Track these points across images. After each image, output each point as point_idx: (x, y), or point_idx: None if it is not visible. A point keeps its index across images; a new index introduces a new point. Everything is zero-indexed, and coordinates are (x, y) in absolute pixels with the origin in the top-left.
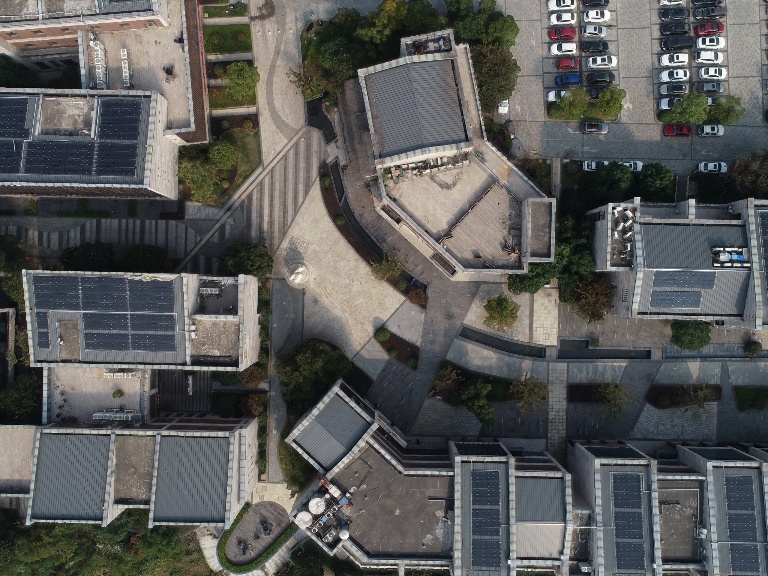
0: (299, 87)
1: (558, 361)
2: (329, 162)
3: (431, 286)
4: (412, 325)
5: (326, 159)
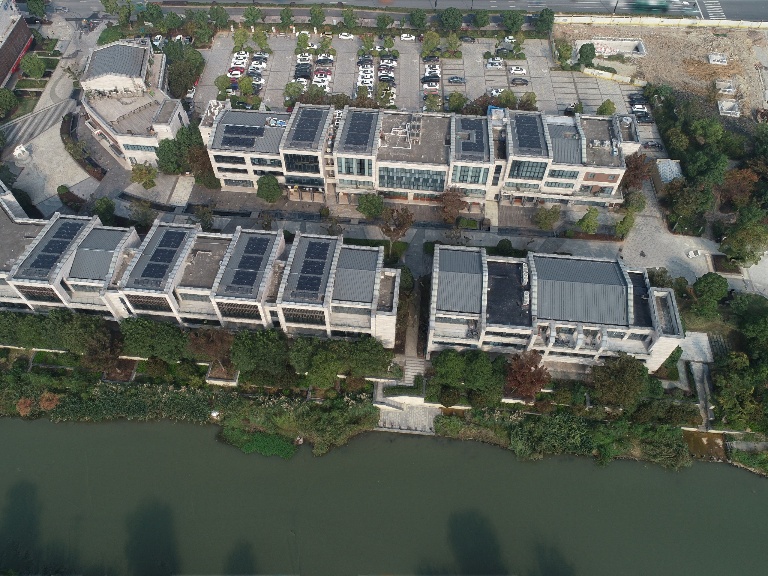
0: (66, 71)
1: (183, 214)
2: (74, 113)
3: (110, 171)
4: (88, 190)
5: (73, 112)
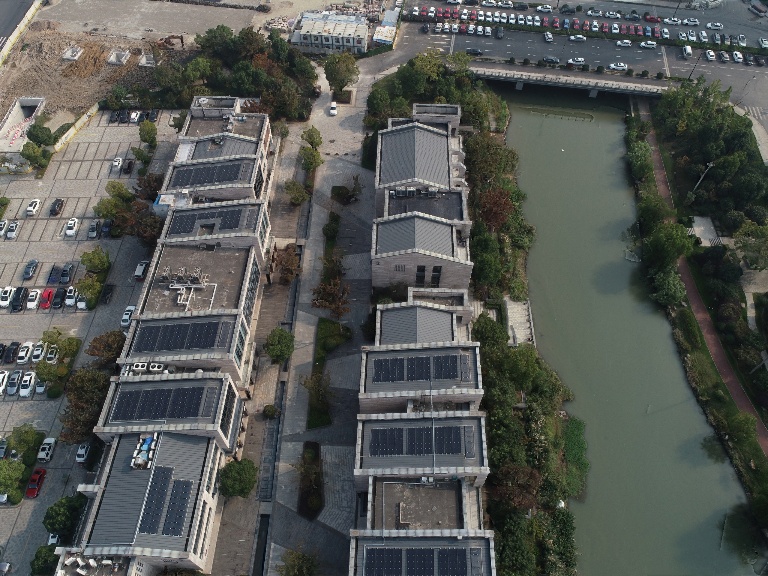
0: None
1: None
2: None
3: None
4: None
5: None
